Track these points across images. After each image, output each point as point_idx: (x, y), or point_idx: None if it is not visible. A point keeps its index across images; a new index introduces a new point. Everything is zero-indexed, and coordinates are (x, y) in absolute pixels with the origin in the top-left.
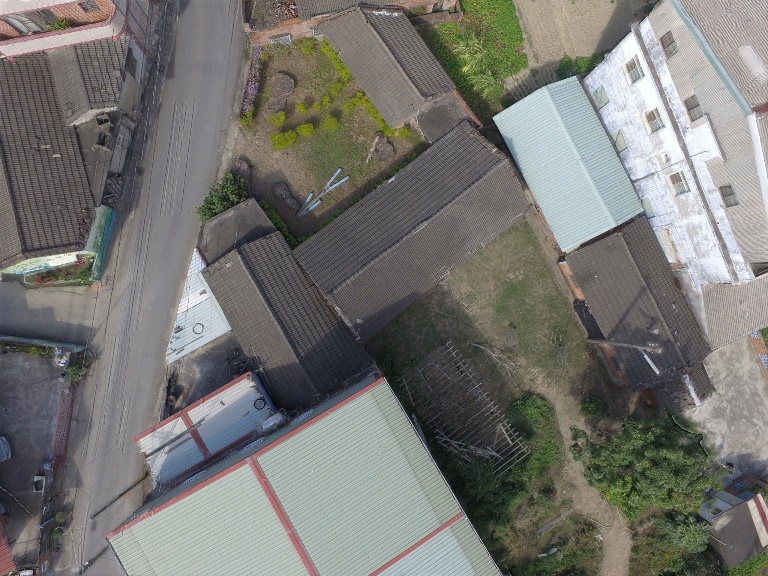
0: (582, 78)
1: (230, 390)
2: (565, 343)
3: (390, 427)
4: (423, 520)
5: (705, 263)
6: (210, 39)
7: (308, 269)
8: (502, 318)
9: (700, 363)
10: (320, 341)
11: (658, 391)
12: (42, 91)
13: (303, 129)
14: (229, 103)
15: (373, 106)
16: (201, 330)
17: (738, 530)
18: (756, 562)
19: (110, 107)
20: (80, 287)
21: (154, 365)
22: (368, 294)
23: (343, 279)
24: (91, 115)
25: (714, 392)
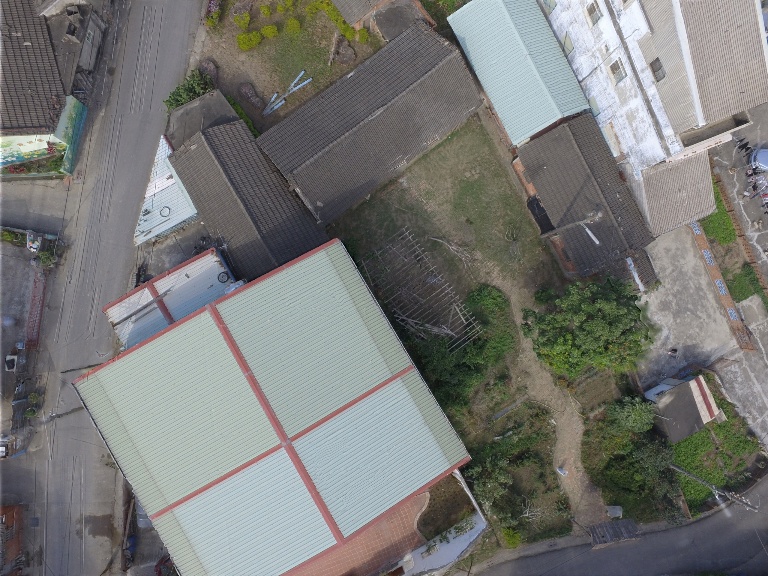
0: None
1: (195, 264)
2: (519, 238)
3: (343, 283)
4: (375, 370)
5: (643, 147)
6: None
7: (270, 154)
8: (459, 214)
9: (645, 253)
10: (282, 222)
11: (605, 279)
12: None
13: (267, 30)
14: (197, 8)
15: (334, 9)
16: (168, 213)
17: (680, 407)
18: (701, 445)
19: None
20: (52, 181)
21: (124, 255)
22: (327, 177)
23: (303, 161)
24: (61, 6)
25: (660, 285)
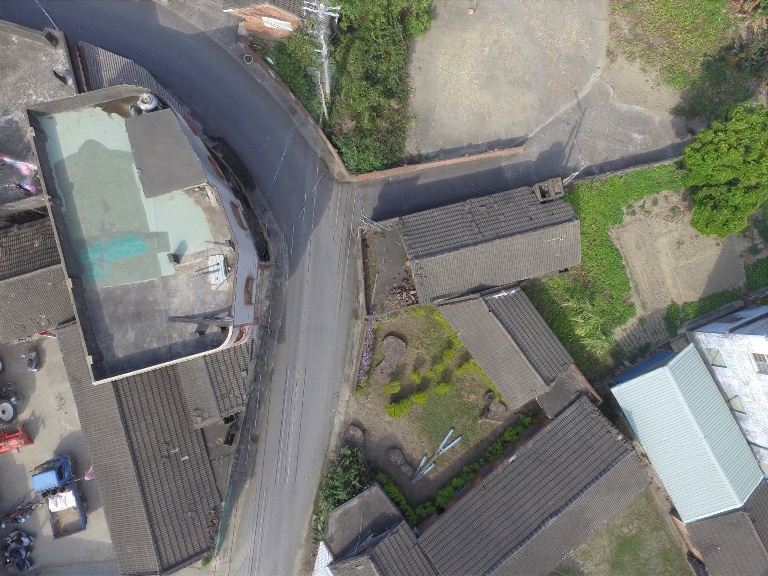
0: (690, 324)
1: None
2: None
3: None
4: None
5: None
6: (320, 301)
7: (436, 563)
8: (617, 574)
9: None
10: None
11: None
12: (169, 392)
13: (418, 399)
14: (340, 365)
15: None
16: None
17: None
18: None
19: (238, 411)
20: (198, 561)
21: None
22: None
23: None
24: None
25: None
